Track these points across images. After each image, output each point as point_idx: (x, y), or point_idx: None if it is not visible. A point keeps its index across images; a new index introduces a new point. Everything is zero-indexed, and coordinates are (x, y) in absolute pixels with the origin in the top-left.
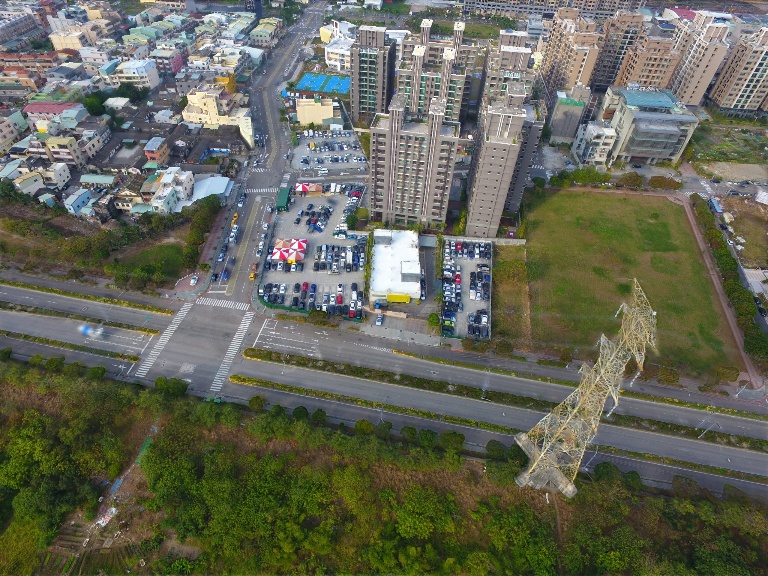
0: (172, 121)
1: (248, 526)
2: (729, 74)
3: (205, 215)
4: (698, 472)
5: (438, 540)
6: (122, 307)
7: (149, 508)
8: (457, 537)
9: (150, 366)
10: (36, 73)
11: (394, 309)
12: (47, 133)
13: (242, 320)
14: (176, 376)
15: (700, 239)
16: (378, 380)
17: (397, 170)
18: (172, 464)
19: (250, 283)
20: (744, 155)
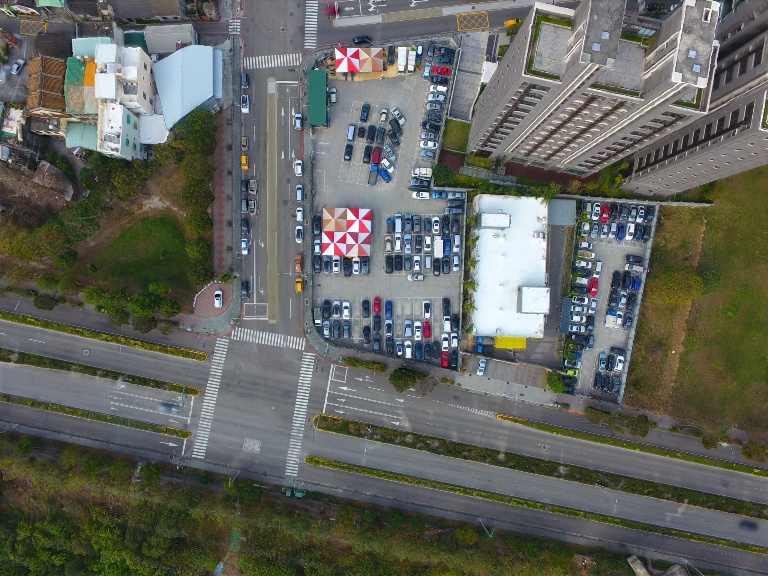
0: None
1: None
2: None
3: (200, 175)
4: None
5: None
6: (135, 348)
7: None
8: None
9: (206, 443)
10: None
11: None
12: None
13: (301, 368)
14: (241, 457)
15: None
16: (479, 461)
17: (546, 124)
18: (271, 569)
19: (298, 298)
20: None
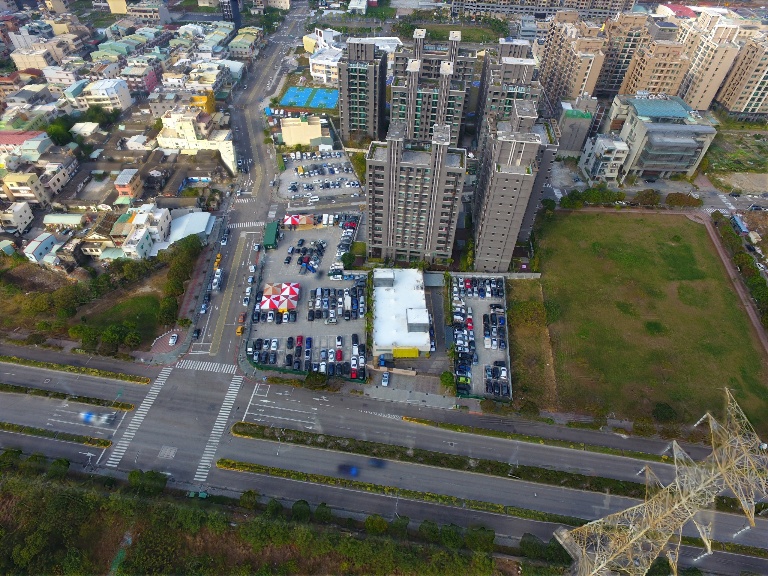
0: (146, 147)
1: None
2: (739, 76)
3: (184, 260)
4: (764, 559)
5: None
6: (91, 376)
7: None
8: None
9: (123, 452)
10: None
11: (401, 365)
12: (5, 169)
13: (229, 386)
14: (154, 464)
15: (727, 263)
16: (388, 457)
17: (397, 204)
18: None
19: (237, 339)
20: (761, 164)
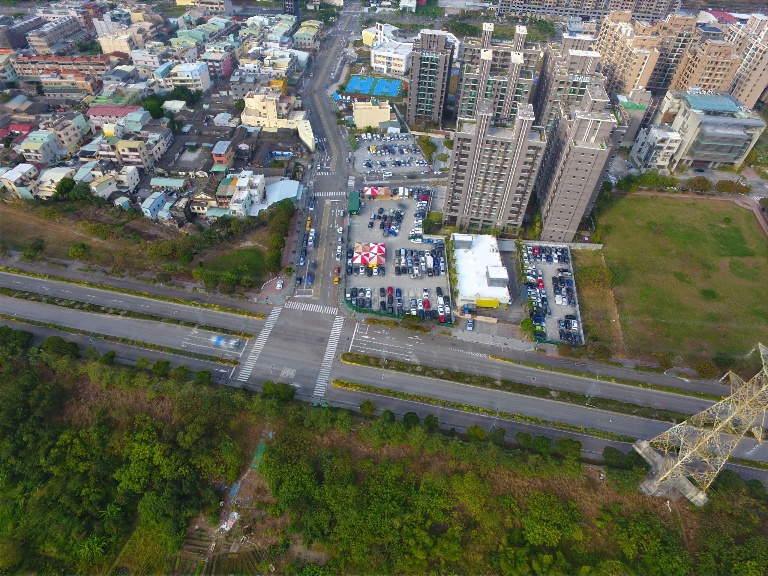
0: (231, 124)
1: (376, 532)
2: None
3: (284, 219)
4: None
5: (565, 547)
6: (213, 311)
7: (272, 513)
8: (585, 545)
9: (251, 370)
10: (92, 76)
11: (483, 314)
12: (115, 136)
13: (333, 324)
14: (278, 380)
15: None
16: (480, 385)
17: (478, 174)
18: (292, 469)
19: (335, 287)
20: None
